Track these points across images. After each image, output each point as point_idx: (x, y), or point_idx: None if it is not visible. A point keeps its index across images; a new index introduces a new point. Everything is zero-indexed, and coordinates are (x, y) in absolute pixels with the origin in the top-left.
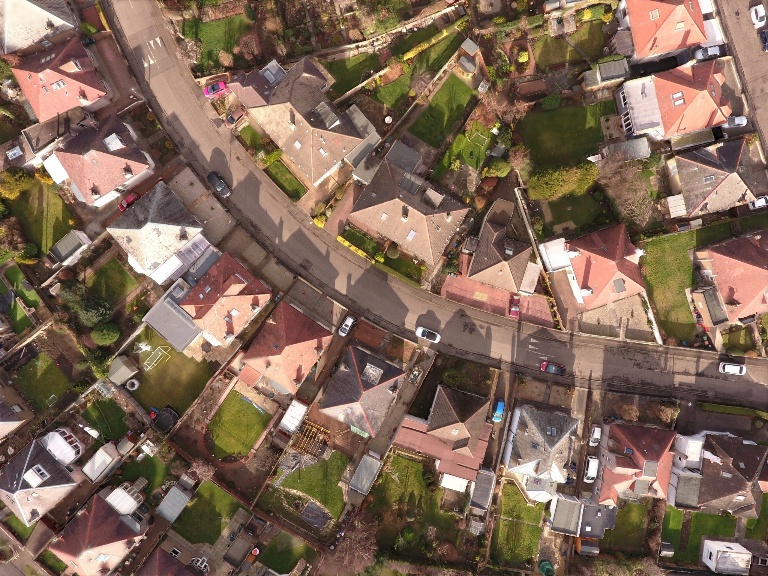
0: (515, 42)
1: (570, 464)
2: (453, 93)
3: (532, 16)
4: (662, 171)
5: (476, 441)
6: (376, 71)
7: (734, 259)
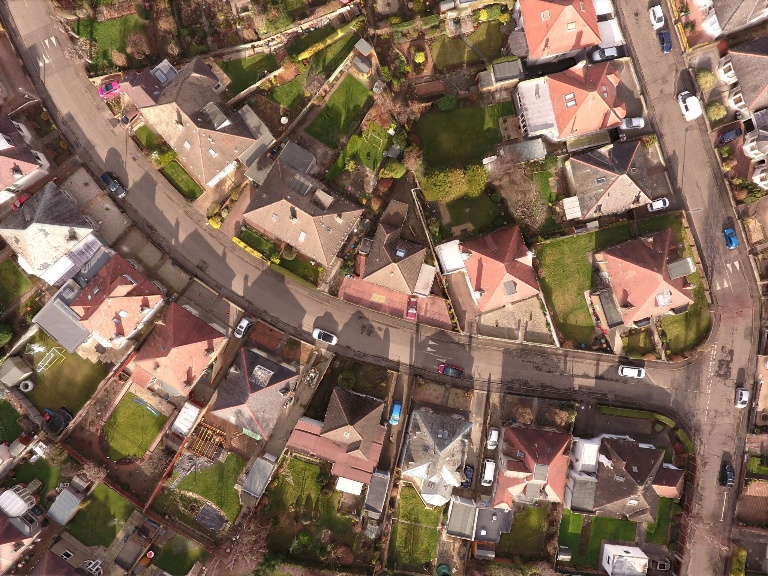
0: (413, 42)
1: (467, 467)
2: (350, 93)
3: (427, 16)
4: (561, 173)
5: (370, 444)
6: (272, 71)
7: (626, 261)
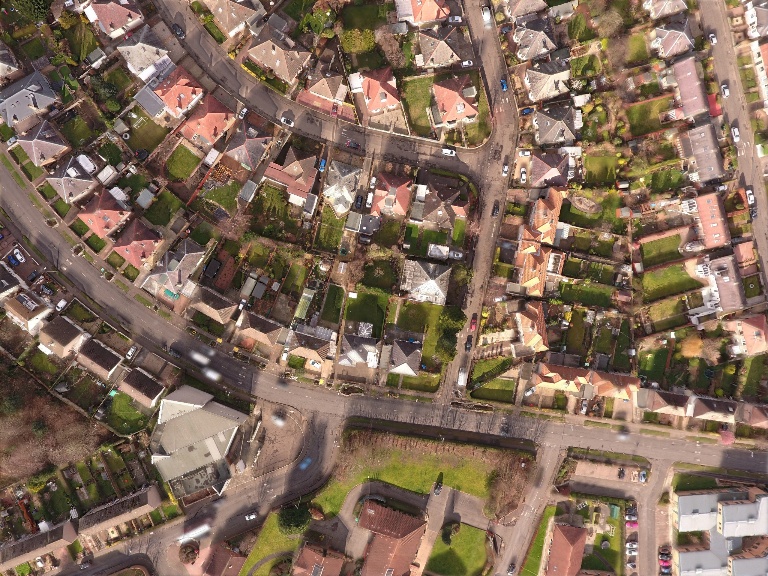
0: None
1: (359, 196)
2: None
3: None
4: (417, 43)
5: (307, 176)
6: None
7: (443, 87)
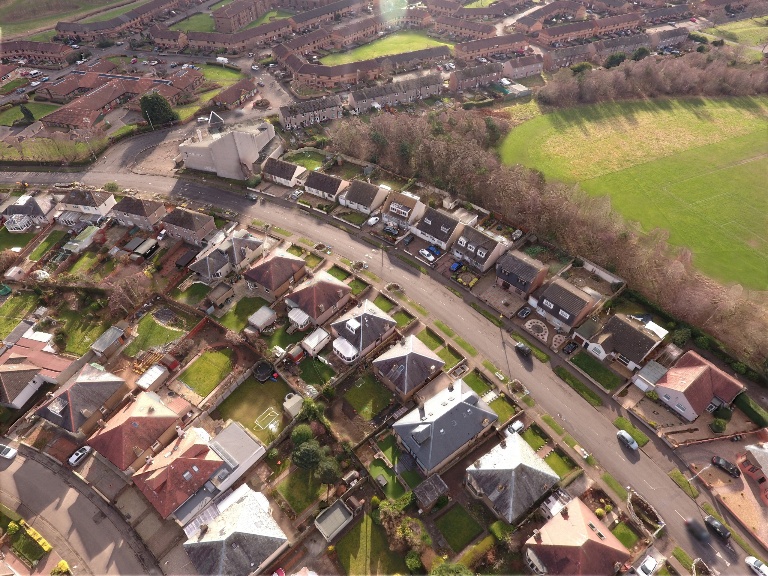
0: None
1: None
2: None
3: None
4: None
5: None
6: None
7: None
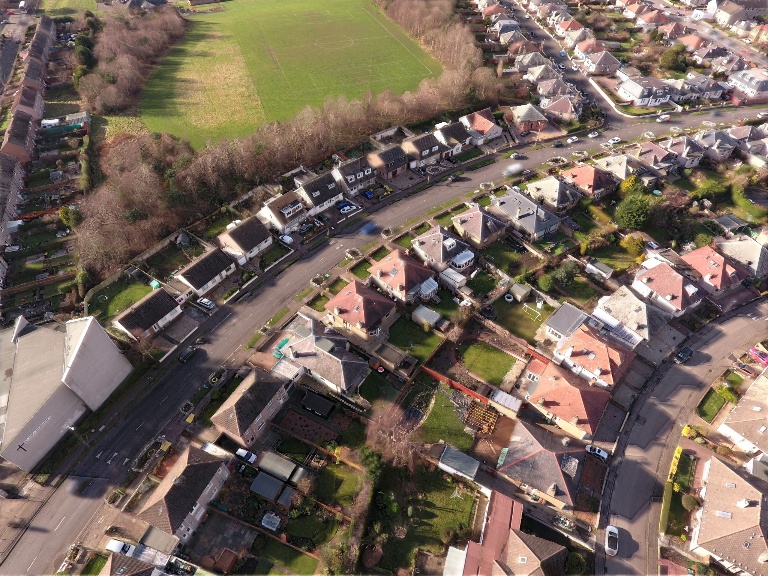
0: None
1: None
2: None
3: None
4: None
5: None
6: None
7: None
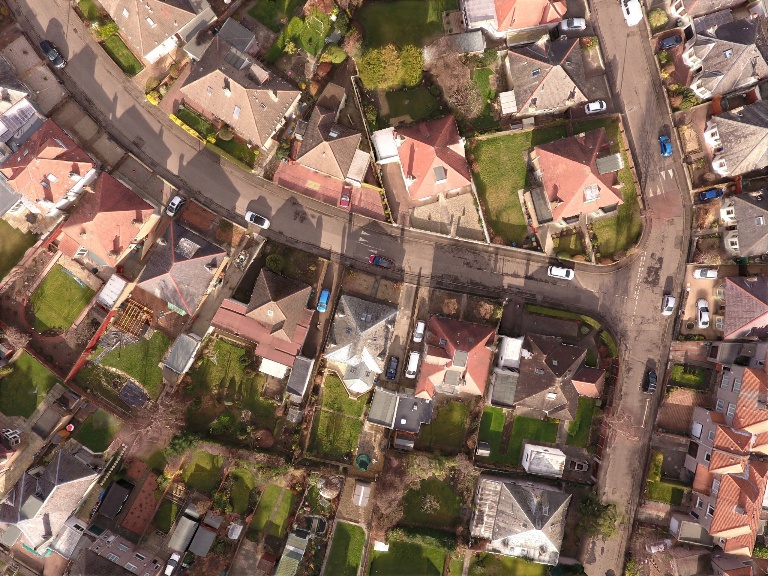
0: None
1: (392, 358)
2: None
3: None
4: (501, 70)
5: (294, 326)
6: None
7: (557, 155)
